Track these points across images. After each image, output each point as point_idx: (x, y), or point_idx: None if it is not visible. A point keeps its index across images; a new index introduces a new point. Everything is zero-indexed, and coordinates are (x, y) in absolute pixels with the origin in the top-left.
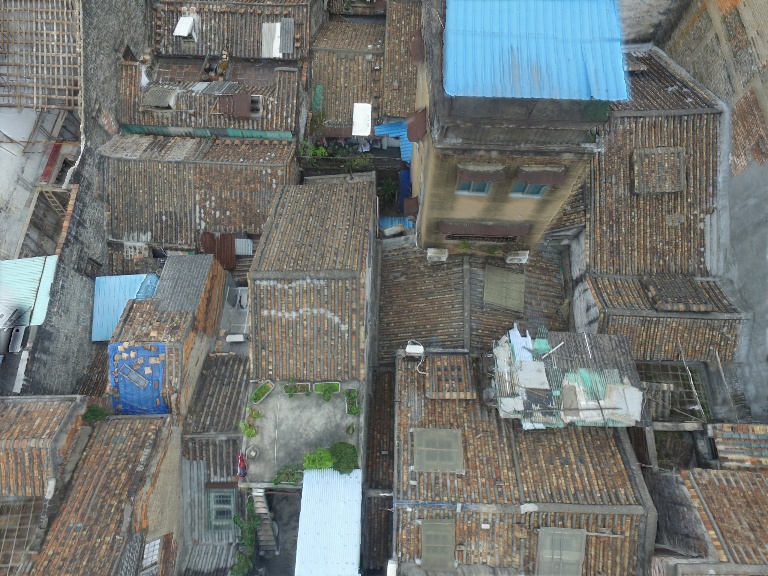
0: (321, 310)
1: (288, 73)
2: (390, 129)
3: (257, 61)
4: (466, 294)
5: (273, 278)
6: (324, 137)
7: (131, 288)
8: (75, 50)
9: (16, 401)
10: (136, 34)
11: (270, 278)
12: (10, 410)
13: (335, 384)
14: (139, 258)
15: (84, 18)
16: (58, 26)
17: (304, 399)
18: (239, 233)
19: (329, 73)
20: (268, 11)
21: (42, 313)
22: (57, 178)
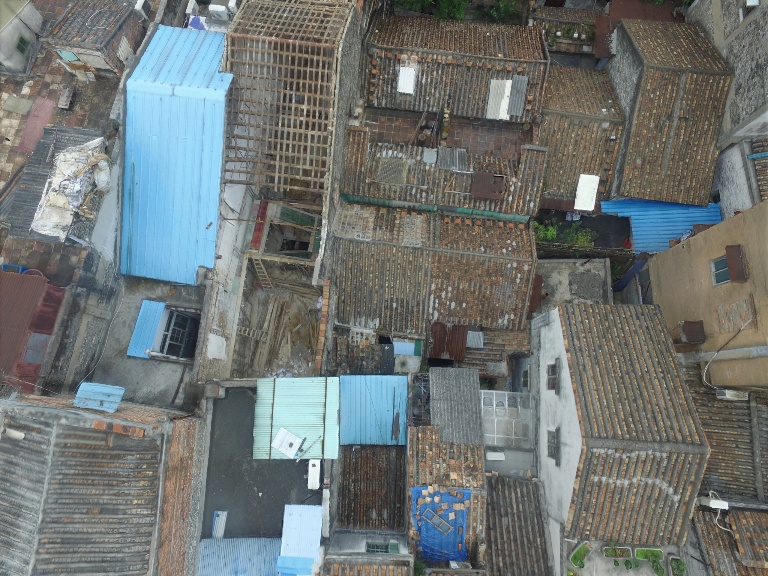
0: (657, 481)
1: (536, 152)
2: (619, 207)
3: (476, 119)
4: (756, 436)
5: (613, 448)
6: (542, 208)
7: (377, 390)
8: (326, 128)
9: (347, 561)
10: (354, 87)
11: (610, 447)
12: (349, 575)
13: (658, 551)
14: (365, 345)
15: (339, 92)
16: (309, 100)
17: (620, 561)
18: (473, 326)
19: (558, 139)
20: (499, 66)
21: (333, 445)
22: (265, 244)
